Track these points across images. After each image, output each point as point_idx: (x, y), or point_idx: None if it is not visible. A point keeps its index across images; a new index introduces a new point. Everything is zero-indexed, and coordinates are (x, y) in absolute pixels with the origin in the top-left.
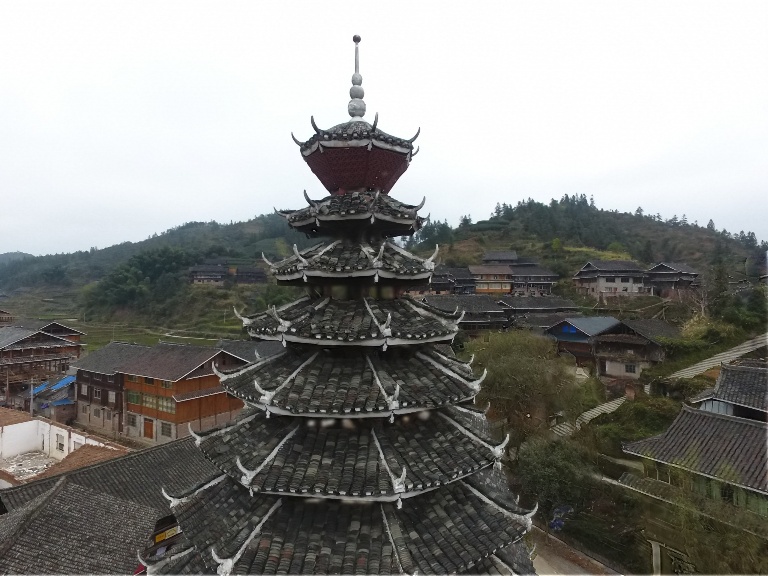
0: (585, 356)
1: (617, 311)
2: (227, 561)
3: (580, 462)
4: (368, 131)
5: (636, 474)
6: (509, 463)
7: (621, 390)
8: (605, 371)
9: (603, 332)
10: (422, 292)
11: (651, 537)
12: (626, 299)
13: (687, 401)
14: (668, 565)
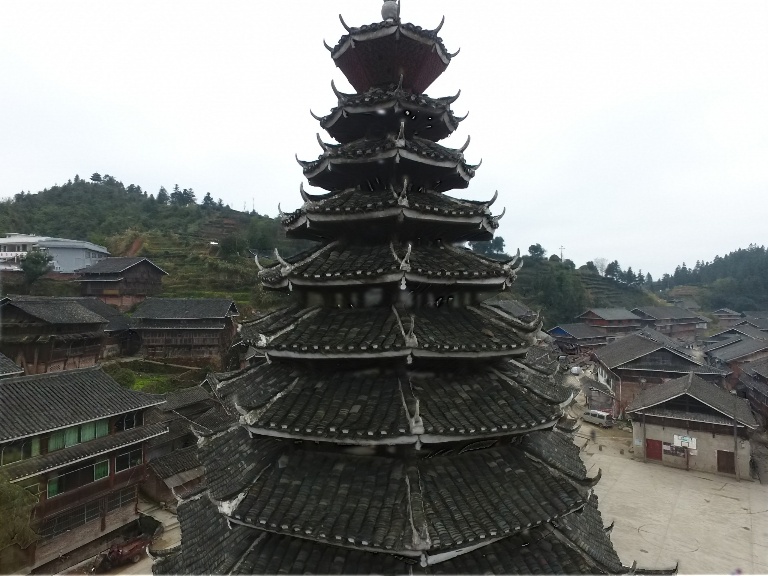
0: None
1: None
2: None
3: None
4: None
5: None
6: None
7: None
8: None
9: None
10: None
11: None
12: None
13: None
14: None
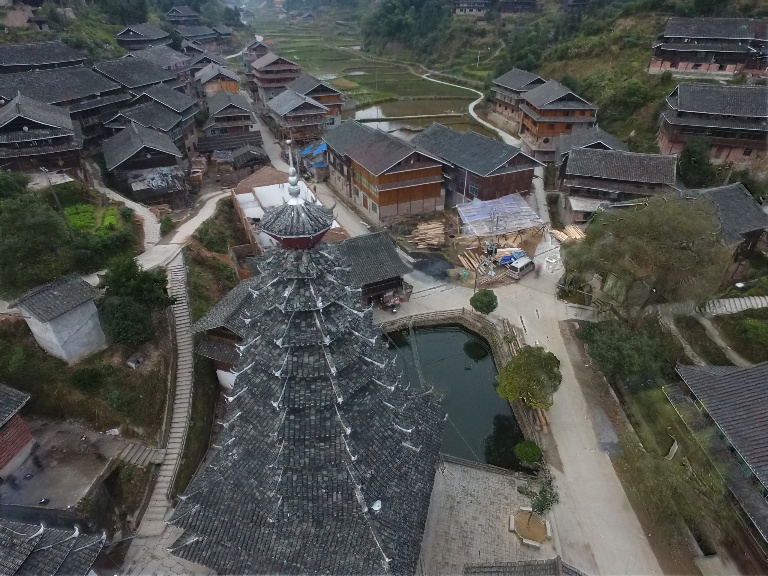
0: None
1: None
2: (231, 398)
3: (649, 356)
4: None
5: None
6: (626, 320)
7: None
8: None
9: None
10: (697, 66)
11: None
12: None
13: None
14: (680, 457)
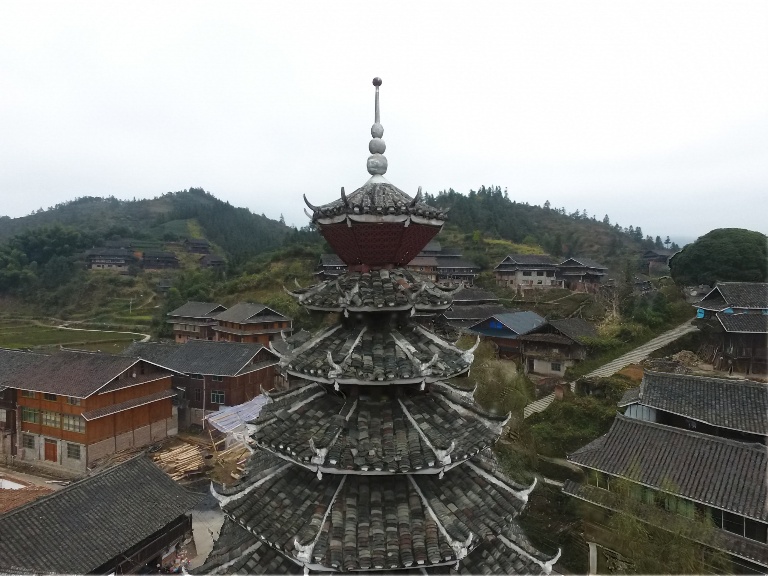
0: (511, 351)
1: (533, 303)
2: None
3: (525, 470)
4: (406, 204)
5: (568, 472)
6: None
7: (549, 388)
8: (533, 369)
9: (531, 332)
10: None
11: (590, 539)
12: (541, 291)
13: (608, 400)
14: (603, 563)
